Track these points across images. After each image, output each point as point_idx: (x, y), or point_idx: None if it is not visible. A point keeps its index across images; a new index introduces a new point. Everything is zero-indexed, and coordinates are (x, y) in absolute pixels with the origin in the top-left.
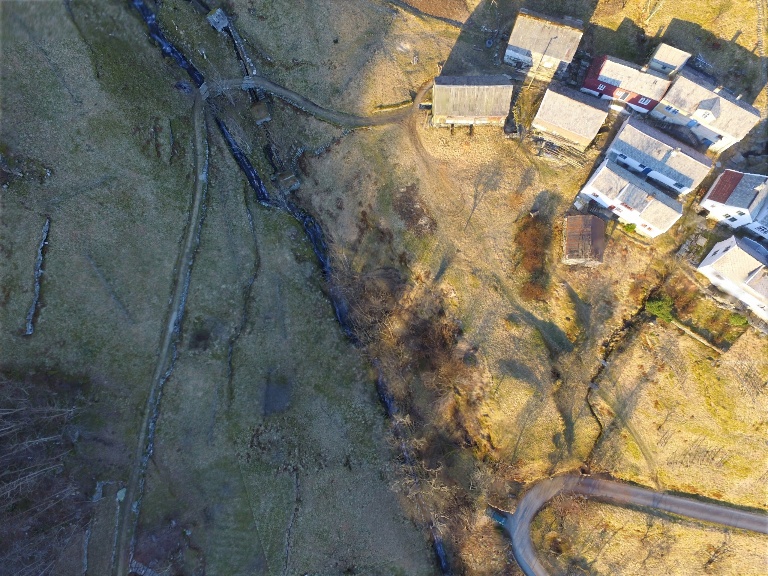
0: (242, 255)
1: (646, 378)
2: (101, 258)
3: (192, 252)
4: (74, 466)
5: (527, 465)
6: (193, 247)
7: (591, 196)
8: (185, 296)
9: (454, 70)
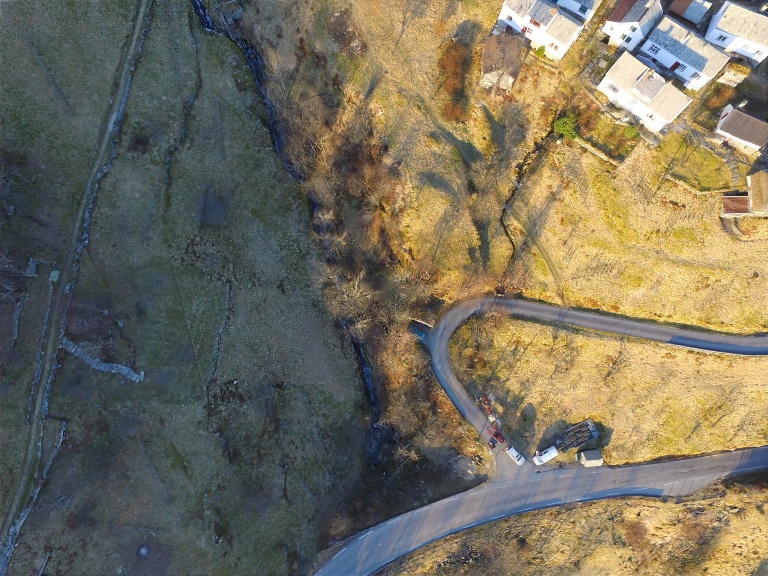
0: (184, 73)
1: (554, 197)
2: (43, 48)
3: (134, 59)
4: (8, 240)
5: (445, 277)
6: (135, 54)
7: (506, 21)
8: (126, 99)
9: None
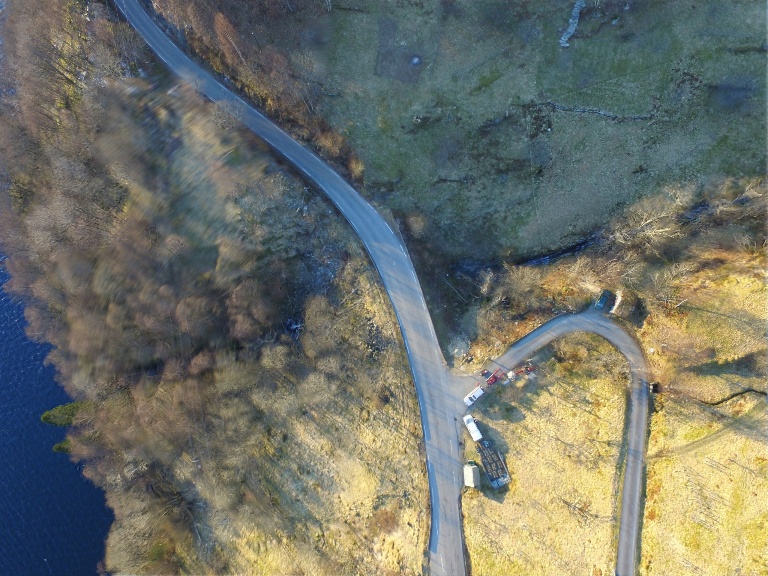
0: None
1: None
2: None
3: None
4: None
5: (675, 323)
6: None
7: None
8: None
9: None
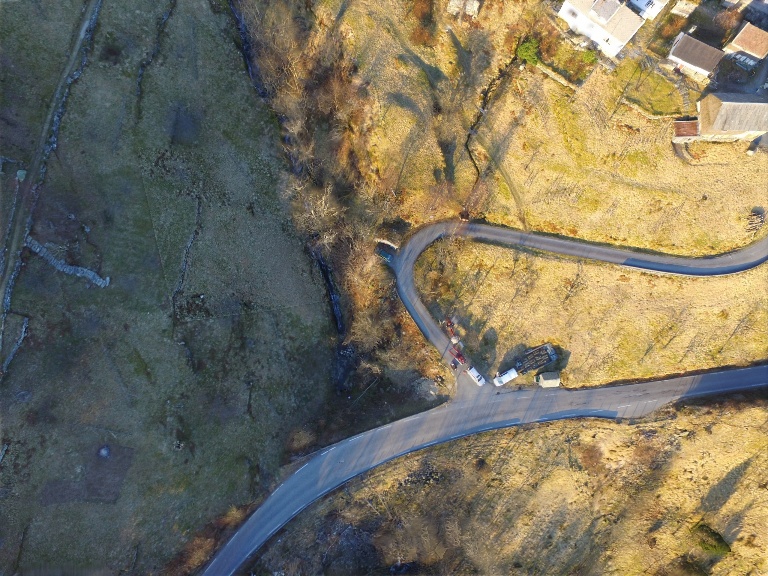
0: None
1: (517, 123)
2: None
3: None
4: None
5: (410, 198)
6: None
7: None
8: (98, 8)
9: None
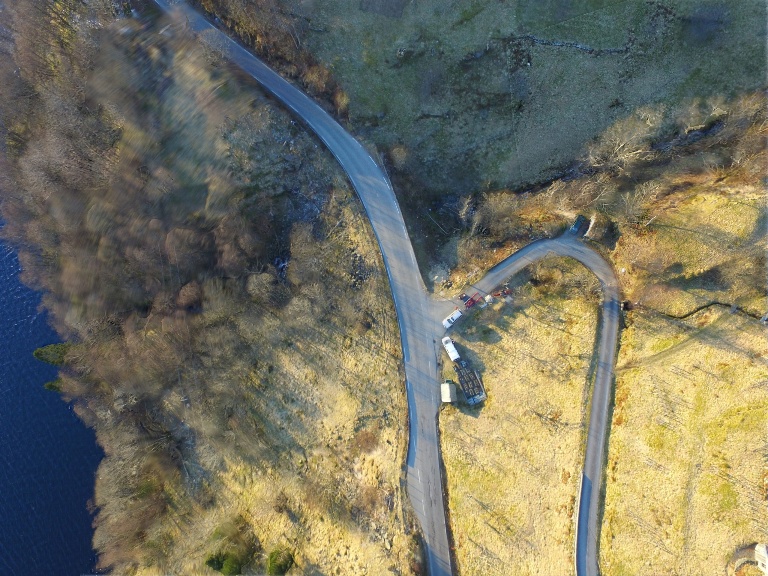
0: None
1: (754, 357)
2: None
3: None
4: None
5: (645, 241)
6: None
7: None
8: None
9: None
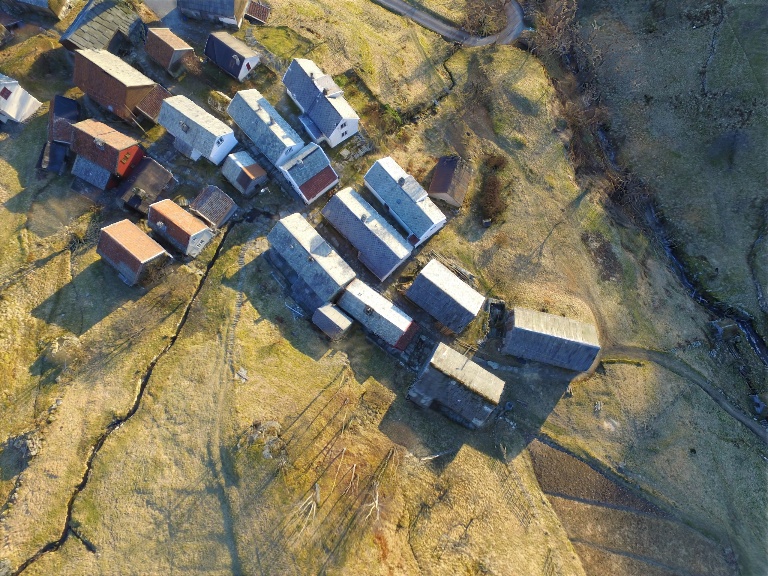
0: None
1: (406, 81)
2: None
3: None
4: None
5: None
6: None
7: None
8: None
9: (552, 386)
